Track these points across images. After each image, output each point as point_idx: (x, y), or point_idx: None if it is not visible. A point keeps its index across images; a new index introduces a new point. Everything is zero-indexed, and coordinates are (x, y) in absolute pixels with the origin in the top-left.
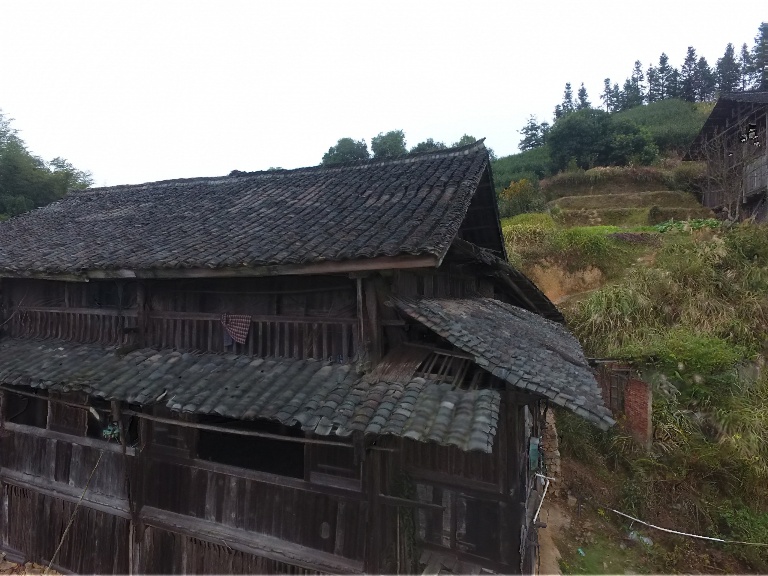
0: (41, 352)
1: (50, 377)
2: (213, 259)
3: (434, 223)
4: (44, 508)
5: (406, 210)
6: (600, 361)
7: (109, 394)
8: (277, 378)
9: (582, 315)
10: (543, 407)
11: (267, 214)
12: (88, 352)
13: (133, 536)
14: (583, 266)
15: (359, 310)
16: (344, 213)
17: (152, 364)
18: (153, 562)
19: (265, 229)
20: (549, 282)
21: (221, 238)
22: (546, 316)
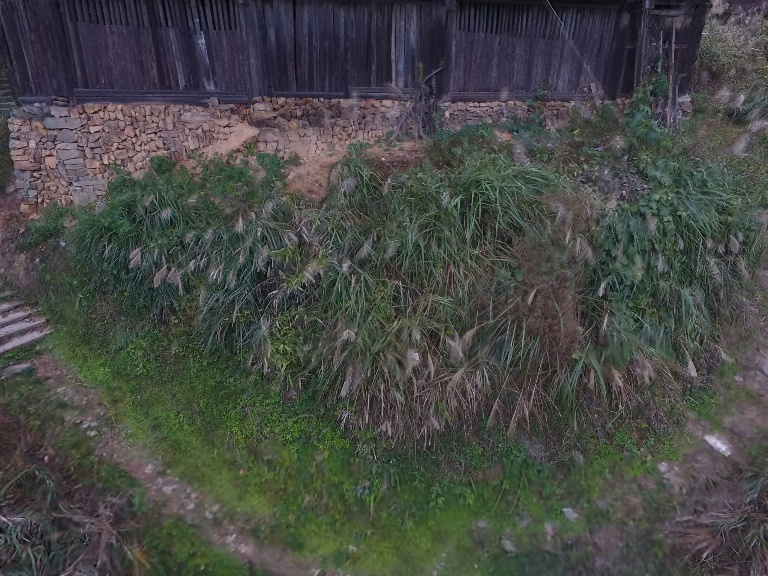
0: None
1: None
2: None
3: None
4: (267, 35)
5: None
6: None
7: None
8: None
9: None
10: None
11: None
12: None
13: (396, 38)
14: None
15: None
16: None
17: None
18: (419, 57)
19: None
20: None
21: None
22: None
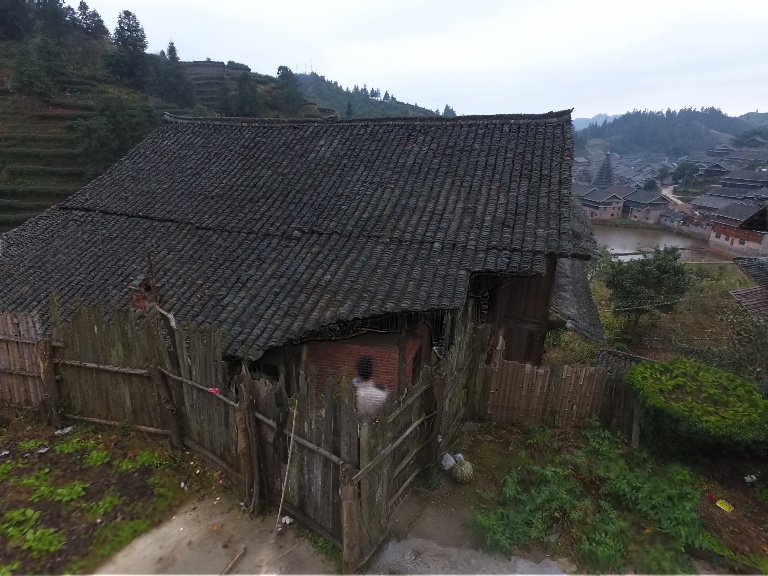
0: None
1: None
2: None
3: None
4: None
5: None
6: None
7: None
8: None
9: None
10: None
11: None
12: None
13: None
14: None
15: None
16: None
17: None
18: None
19: None
20: None
21: None
22: None
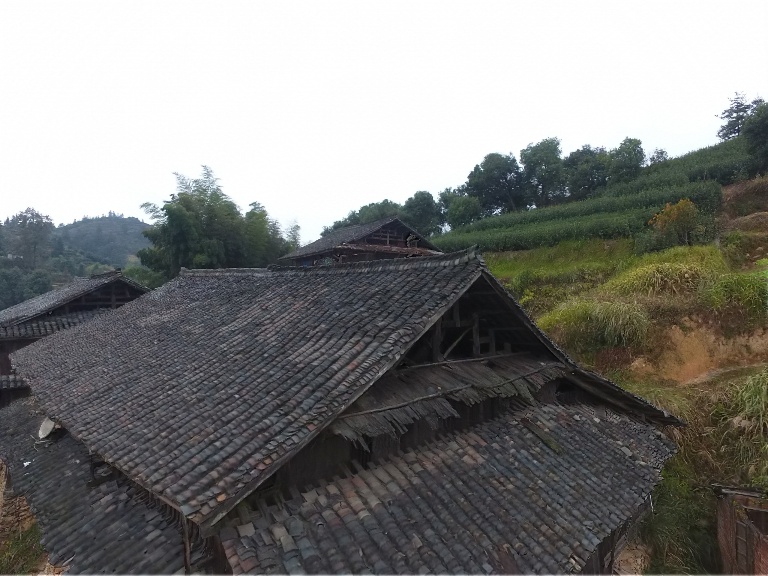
0: (65, 463)
1: (40, 503)
2: (98, 442)
3: (276, 432)
4: None
5: (296, 386)
6: (730, 491)
7: (48, 542)
8: (145, 569)
9: (732, 404)
10: (629, 544)
11: (231, 346)
12: (84, 473)
13: None
14: (748, 329)
15: (184, 532)
16: (264, 368)
17: (98, 508)
18: None
19: (195, 382)
20: (691, 350)
21: (162, 388)
22: (651, 416)
